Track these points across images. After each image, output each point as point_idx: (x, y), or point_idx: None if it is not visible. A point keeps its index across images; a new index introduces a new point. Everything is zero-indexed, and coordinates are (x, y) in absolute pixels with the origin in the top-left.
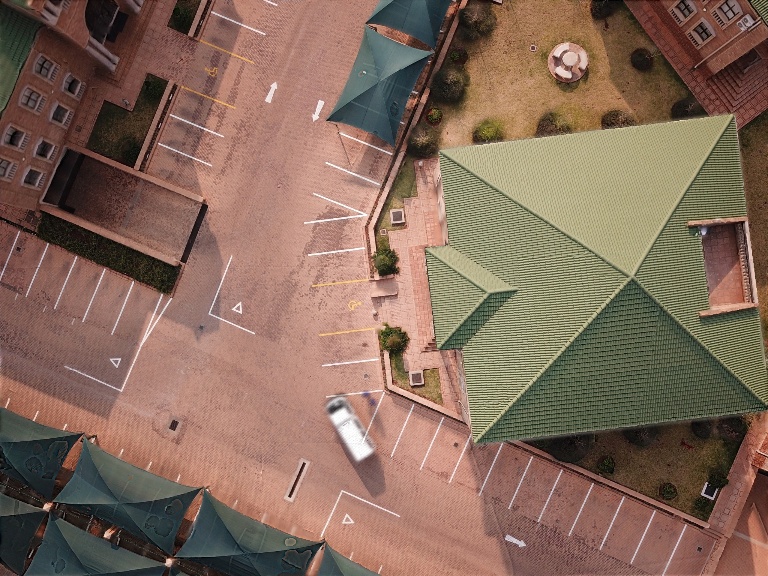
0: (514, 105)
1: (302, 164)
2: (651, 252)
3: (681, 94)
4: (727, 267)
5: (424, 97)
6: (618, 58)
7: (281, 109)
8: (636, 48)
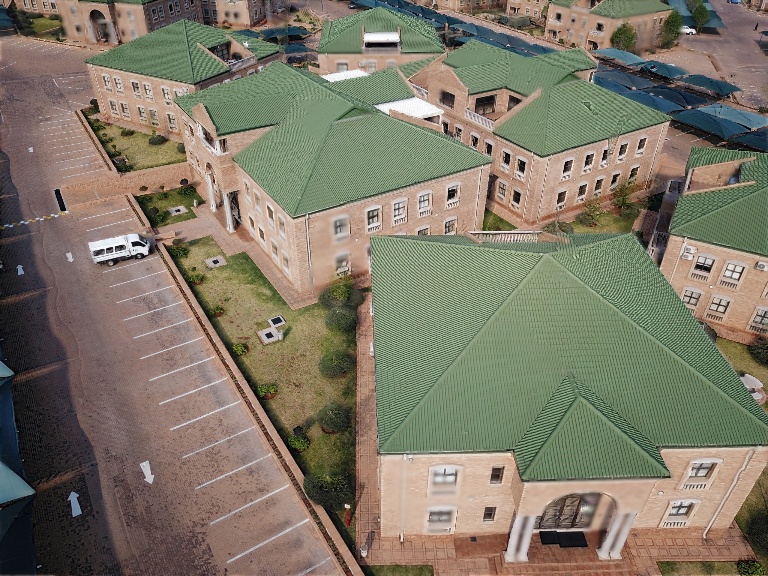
0: None
1: None
2: None
3: None
4: None
5: None
6: None
7: None
8: None
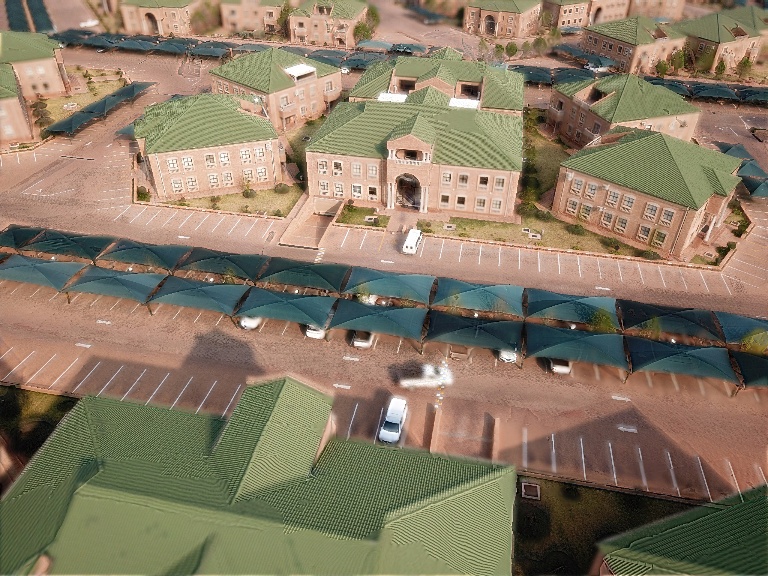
0: None
1: None
2: None
3: None
4: None
5: None
6: None
7: (762, 159)
8: None
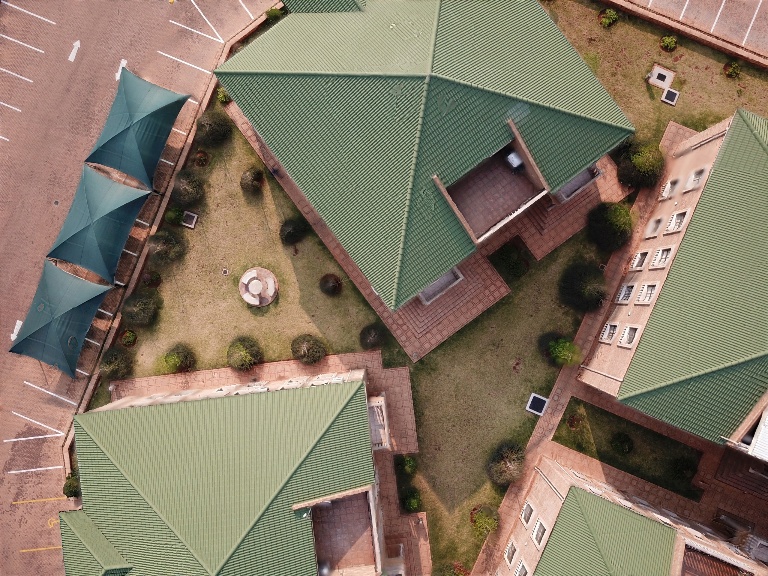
0: (207, 328)
1: (1, 383)
2: (241, 546)
3: (369, 319)
4: (361, 529)
5: (116, 321)
6: (307, 283)
7: None
8: (325, 273)
